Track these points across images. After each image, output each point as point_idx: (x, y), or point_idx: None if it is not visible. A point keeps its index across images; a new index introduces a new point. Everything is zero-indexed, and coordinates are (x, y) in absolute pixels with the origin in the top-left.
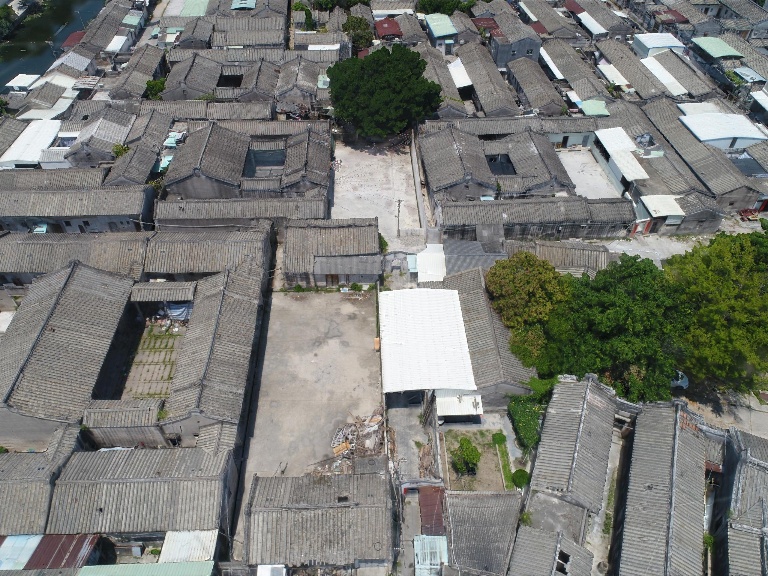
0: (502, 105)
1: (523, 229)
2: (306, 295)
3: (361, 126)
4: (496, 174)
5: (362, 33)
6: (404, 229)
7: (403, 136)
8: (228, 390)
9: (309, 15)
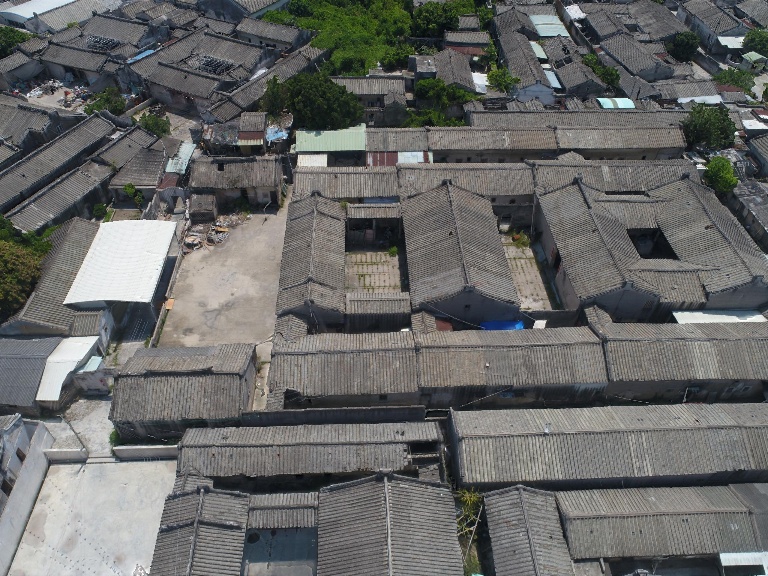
0: None
1: None
2: None
3: None
4: None
5: None
6: (74, 449)
7: None
8: None
9: None
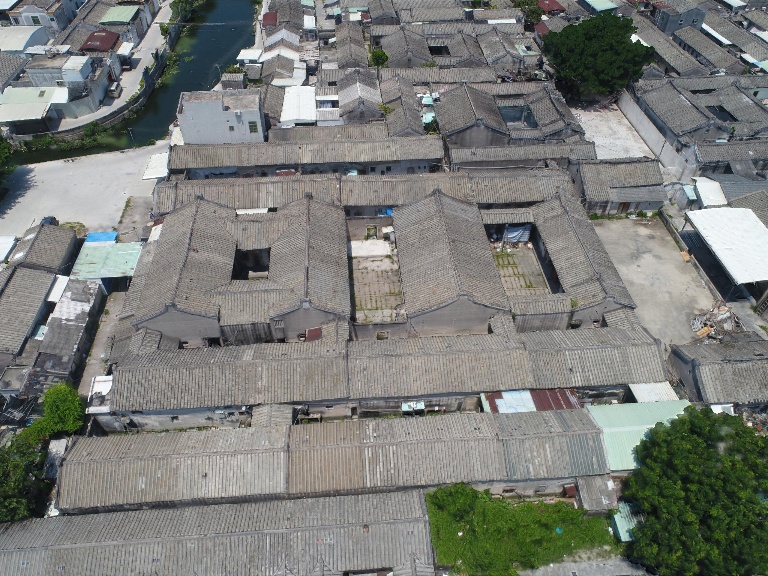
0: (696, 66)
1: (765, 164)
2: (602, 222)
3: (585, 85)
4: None
5: (535, 8)
6: None
7: (618, 94)
8: (615, 284)
9: None
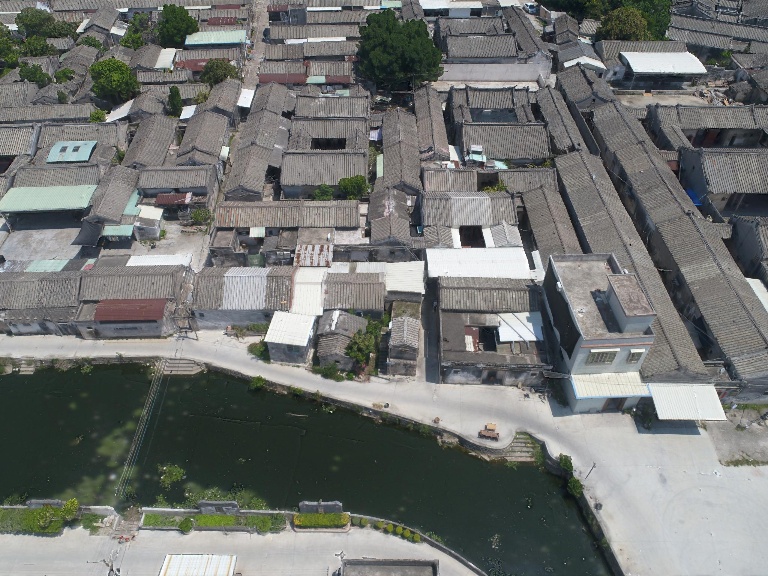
0: None
1: None
2: None
3: (435, 74)
4: None
5: None
6: None
7: None
8: None
9: (178, 91)
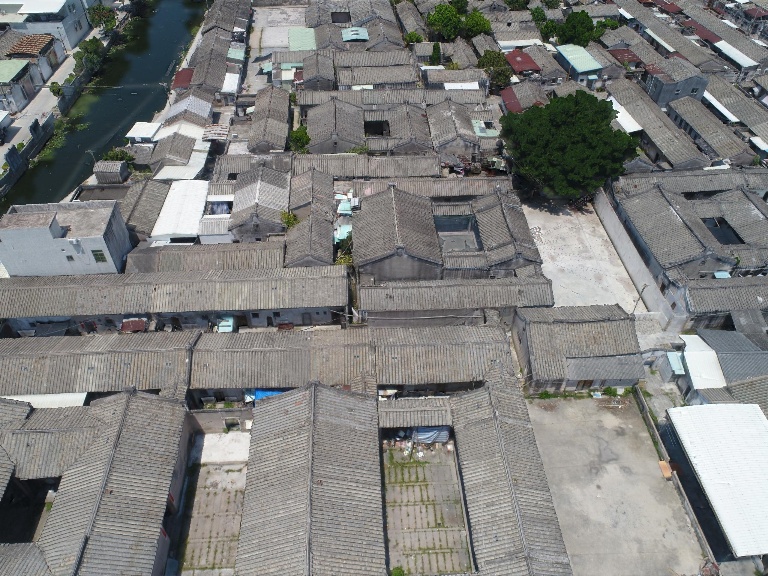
0: (693, 156)
1: None
2: (555, 403)
3: (550, 185)
4: (720, 243)
5: (501, 69)
6: (637, 313)
7: (593, 195)
8: (553, 560)
9: (438, 49)
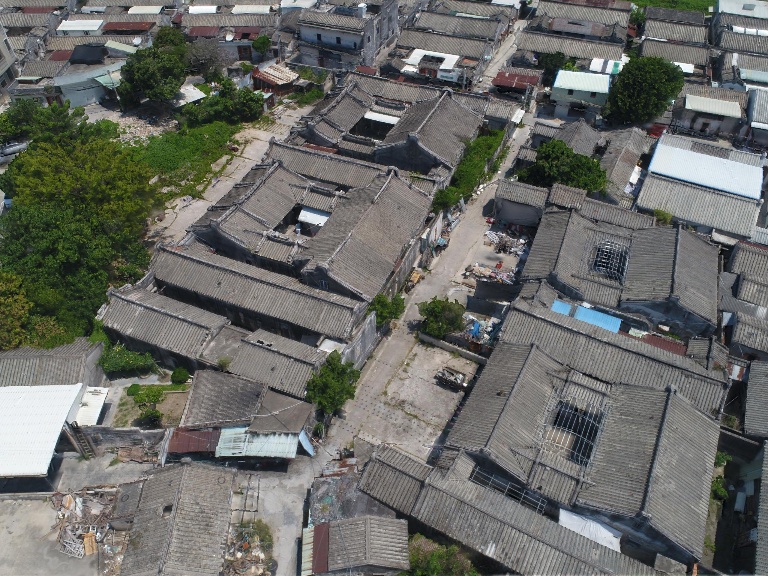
0: None
1: None
2: None
3: None
4: None
5: None
6: None
7: None
8: None
9: None
